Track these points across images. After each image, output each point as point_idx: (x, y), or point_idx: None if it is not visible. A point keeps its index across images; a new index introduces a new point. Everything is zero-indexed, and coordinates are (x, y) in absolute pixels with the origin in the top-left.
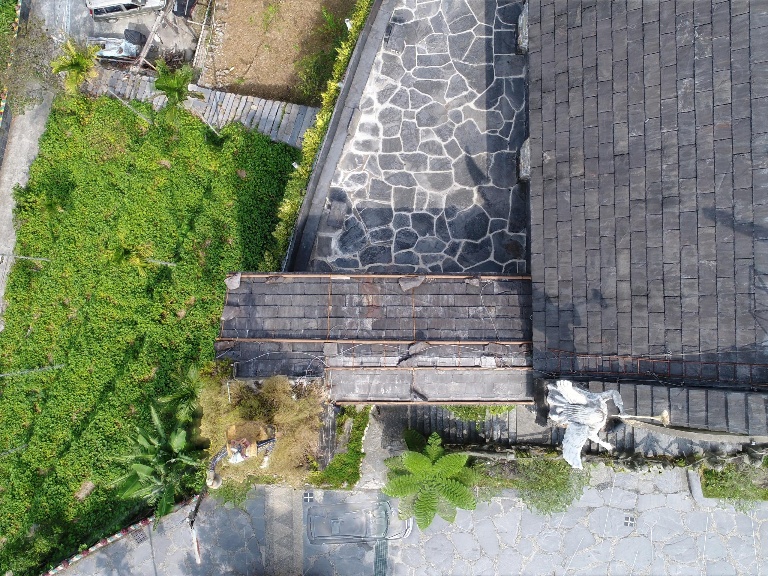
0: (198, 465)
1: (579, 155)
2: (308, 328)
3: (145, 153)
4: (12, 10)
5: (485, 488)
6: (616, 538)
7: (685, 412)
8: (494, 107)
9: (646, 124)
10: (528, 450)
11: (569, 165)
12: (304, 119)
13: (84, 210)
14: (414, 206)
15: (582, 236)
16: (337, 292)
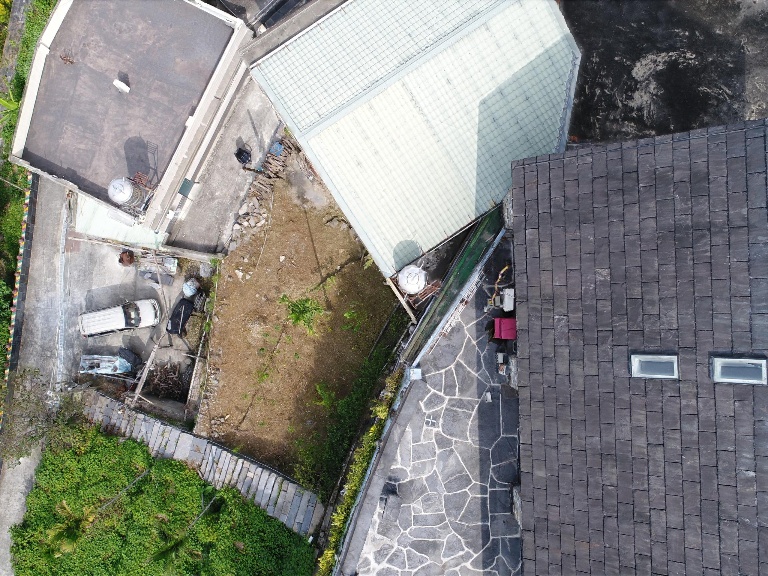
0: None
1: None
2: None
3: (142, 507)
4: (5, 332)
5: None
6: None
7: None
8: (491, 567)
9: None
10: None
11: None
12: (301, 503)
13: (82, 554)
14: None
15: None
16: None
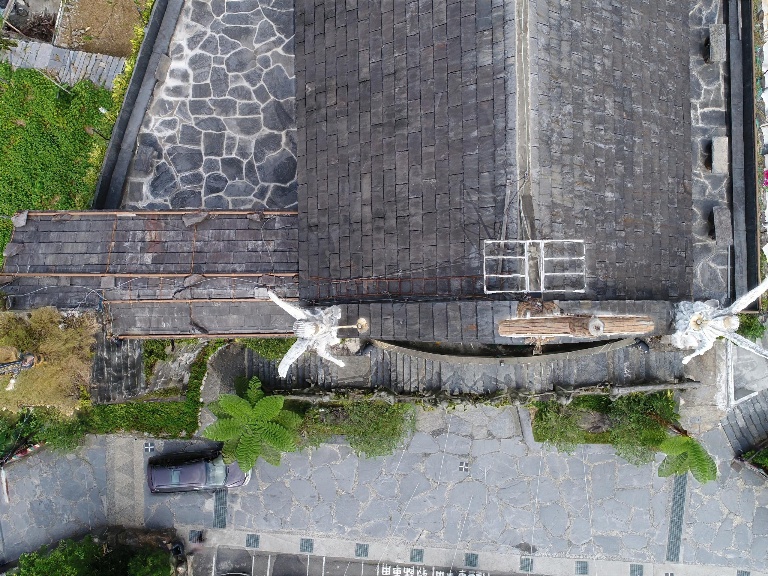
0: (33, 414)
1: (333, 85)
2: (89, 263)
3: (0, 113)
4: None
5: (312, 432)
6: (451, 483)
7: (405, 326)
8: None
9: (382, 49)
10: (347, 393)
11: (325, 95)
12: None
13: None
14: (224, 151)
15: (335, 164)
16: (121, 229)
